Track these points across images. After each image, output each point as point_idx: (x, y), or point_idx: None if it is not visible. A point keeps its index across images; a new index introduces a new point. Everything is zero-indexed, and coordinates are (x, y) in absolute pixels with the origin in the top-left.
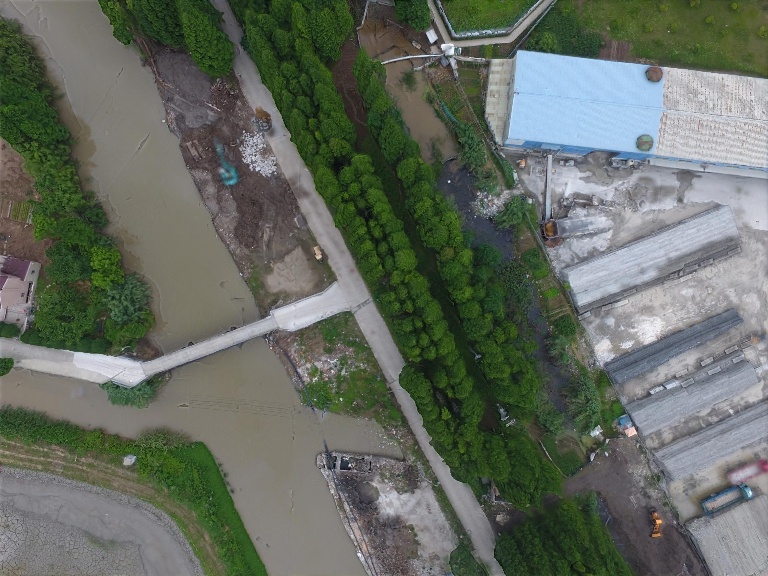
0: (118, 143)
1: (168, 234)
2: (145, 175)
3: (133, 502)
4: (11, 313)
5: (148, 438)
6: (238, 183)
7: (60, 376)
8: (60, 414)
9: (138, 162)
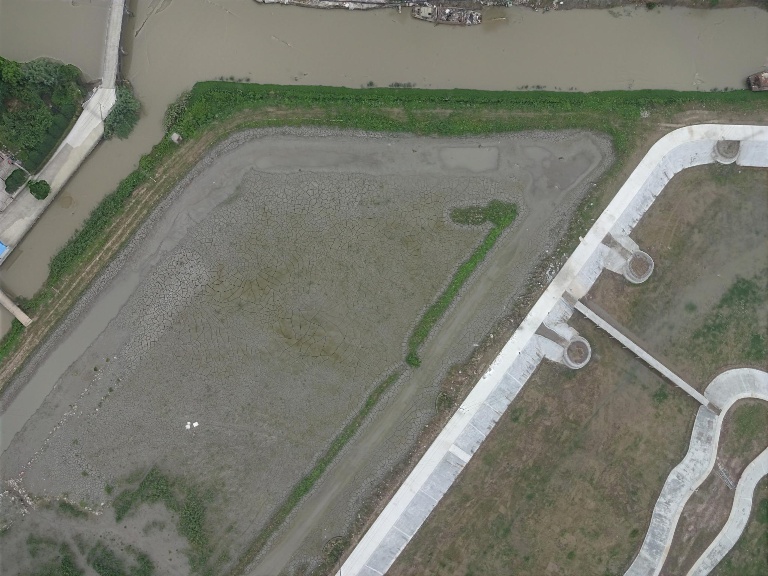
0: None
1: (12, 39)
2: None
3: (213, 155)
4: (5, 177)
5: (167, 116)
6: None
7: (81, 166)
8: (113, 184)
9: None
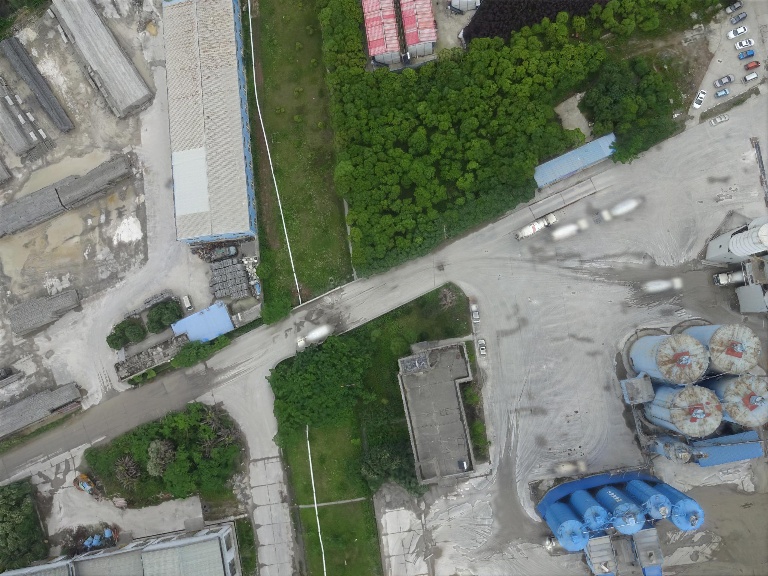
0: None
1: None
2: None
3: None
4: None
5: None
6: None
7: None
8: None
9: None
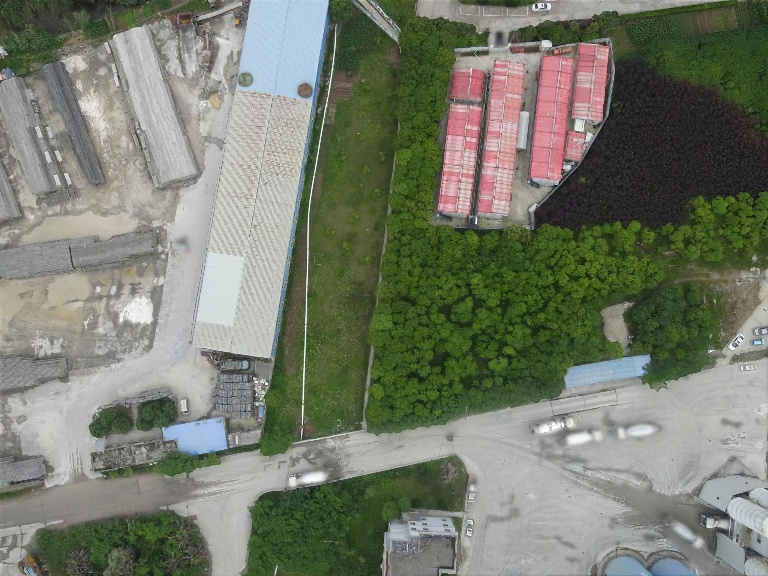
0: None
1: None
2: None
3: None
4: None
5: None
6: None
7: None
8: None
9: None
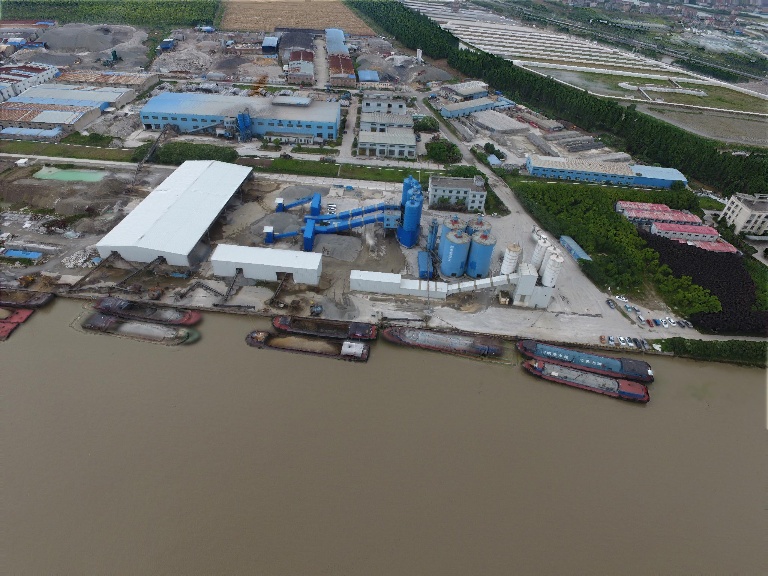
0: None
1: None
2: None
3: None
4: None
5: (726, 147)
6: None
7: None
8: None
9: None
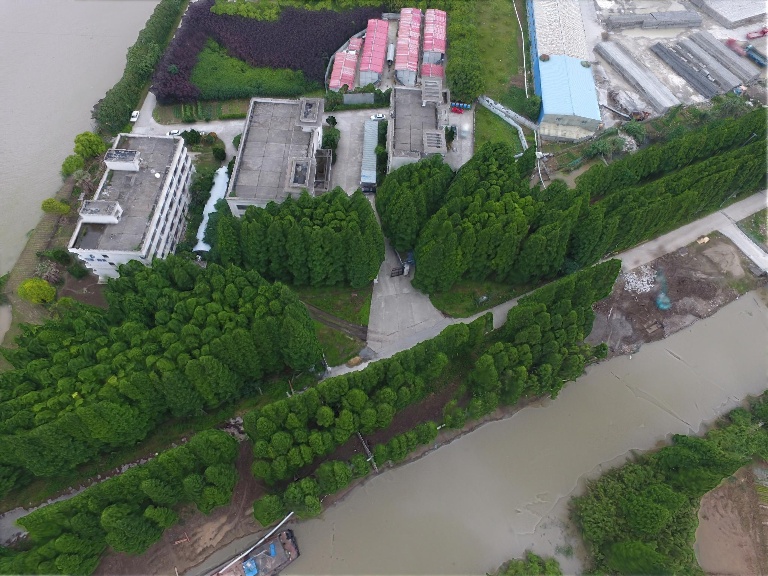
0: (650, 414)
1: (717, 369)
2: (676, 384)
3: None
4: None
5: None
6: (668, 296)
7: None
8: None
9: (666, 390)
